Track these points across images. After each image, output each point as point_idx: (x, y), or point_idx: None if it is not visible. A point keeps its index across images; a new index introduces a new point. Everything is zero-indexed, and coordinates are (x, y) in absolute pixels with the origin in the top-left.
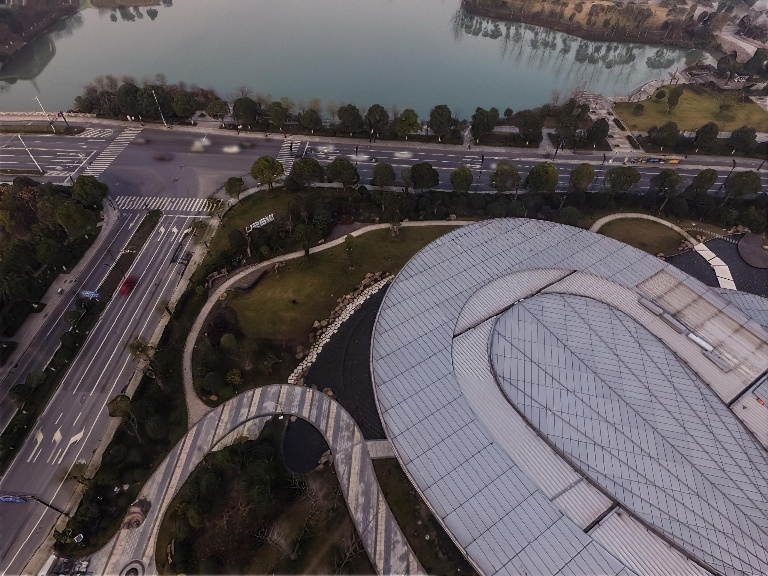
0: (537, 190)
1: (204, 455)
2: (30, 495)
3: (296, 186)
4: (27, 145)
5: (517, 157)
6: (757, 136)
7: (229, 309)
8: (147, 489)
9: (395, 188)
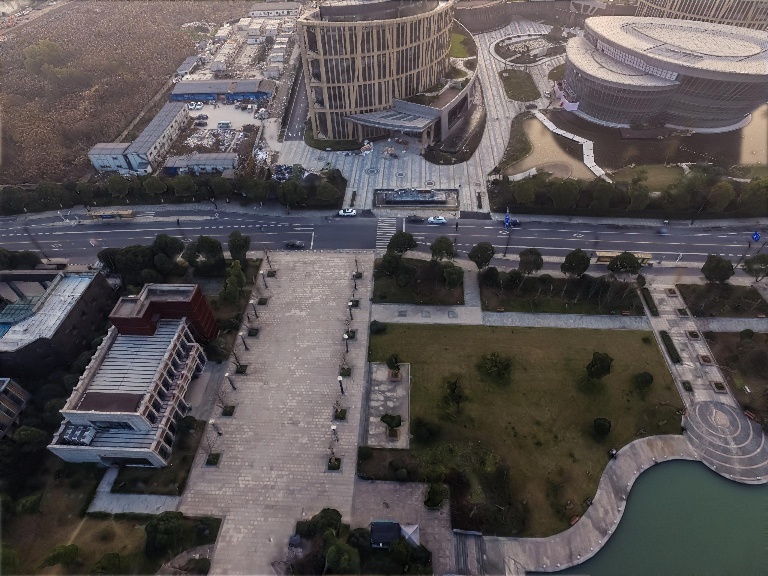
0: None
1: None
2: None
3: None
4: None
5: None
6: (470, 316)
7: None
8: None
9: None
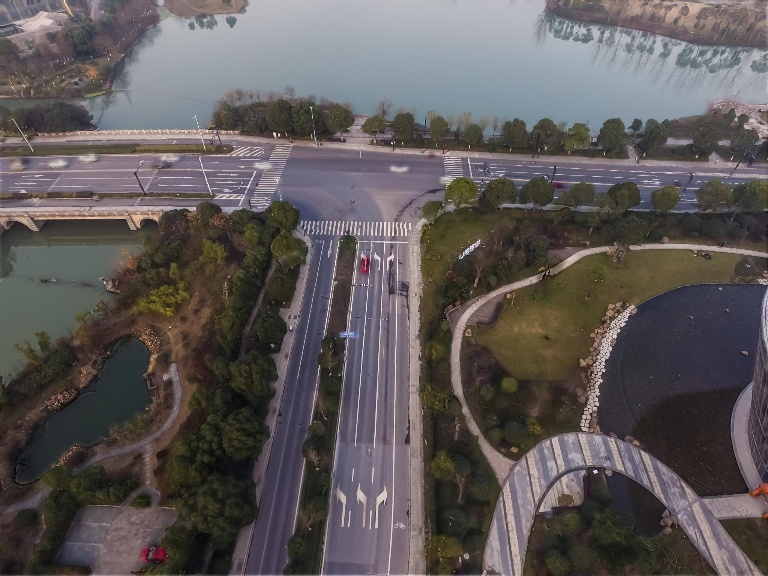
0: (746, 209)
1: (533, 517)
2: (363, 566)
3: (490, 208)
4: (183, 166)
5: (692, 172)
6: None
7: (481, 347)
8: (489, 558)
9: (583, 208)
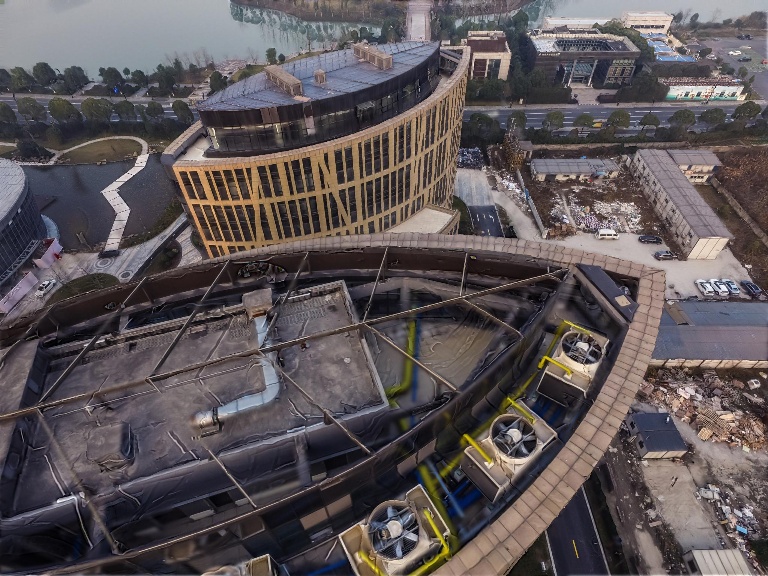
0: (58, 120)
1: None
2: None
3: None
4: None
5: None
6: None
7: None
8: None
9: None
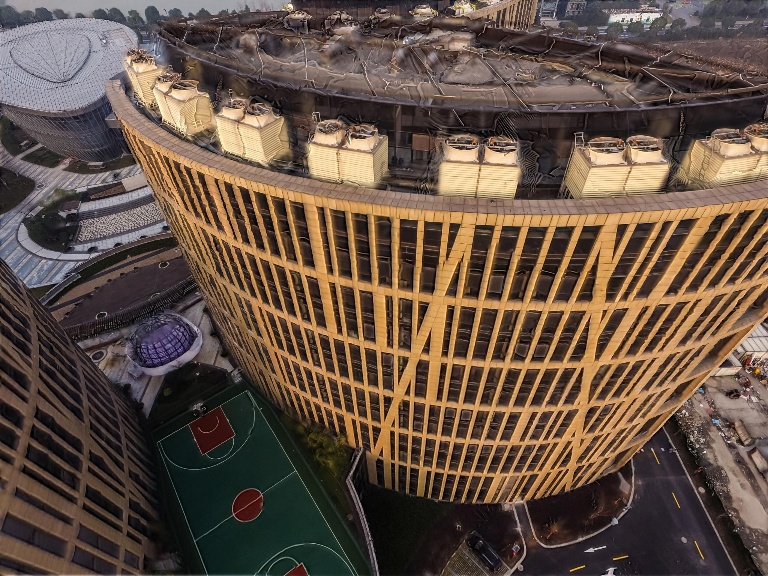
0: None
1: None
2: None
3: None
4: None
5: None
6: None
7: None
8: None
9: None
